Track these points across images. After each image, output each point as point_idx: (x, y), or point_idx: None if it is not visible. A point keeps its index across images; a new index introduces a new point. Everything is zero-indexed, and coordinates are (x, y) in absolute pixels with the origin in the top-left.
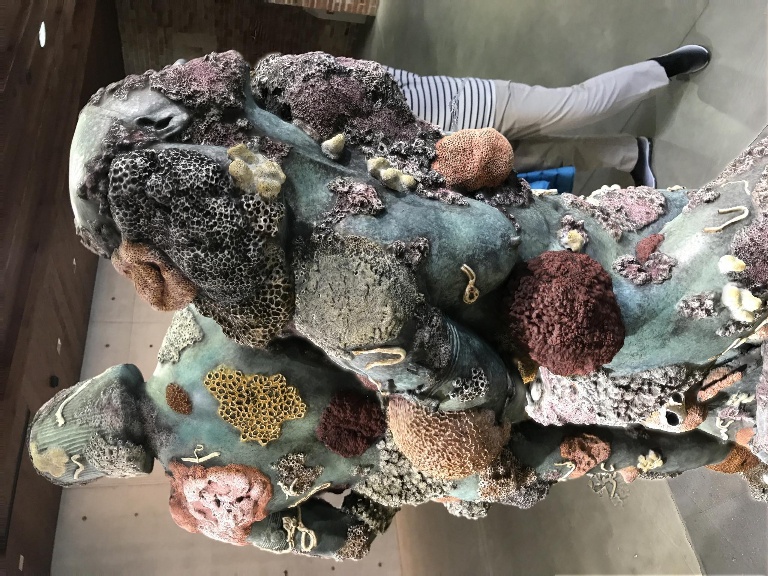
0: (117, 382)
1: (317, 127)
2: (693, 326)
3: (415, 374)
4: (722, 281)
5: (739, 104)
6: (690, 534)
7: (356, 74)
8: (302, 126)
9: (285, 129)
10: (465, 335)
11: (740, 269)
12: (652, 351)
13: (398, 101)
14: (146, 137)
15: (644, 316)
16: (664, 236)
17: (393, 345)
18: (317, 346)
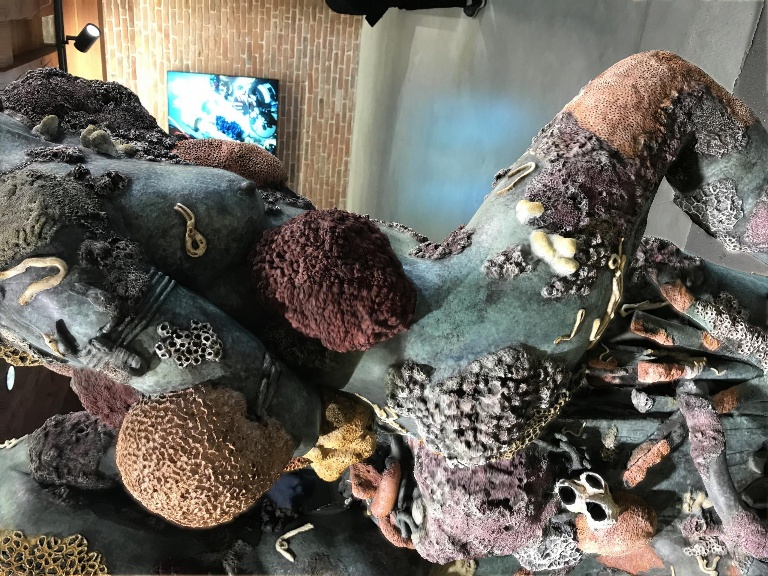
0: None
1: (28, 113)
2: (509, 288)
3: (81, 295)
4: (526, 231)
5: None
6: None
7: (84, 80)
8: (13, 115)
9: None
10: (193, 295)
11: (538, 210)
12: (470, 328)
13: (136, 107)
14: None
15: (446, 285)
16: None
17: (46, 254)
18: (142, 505)
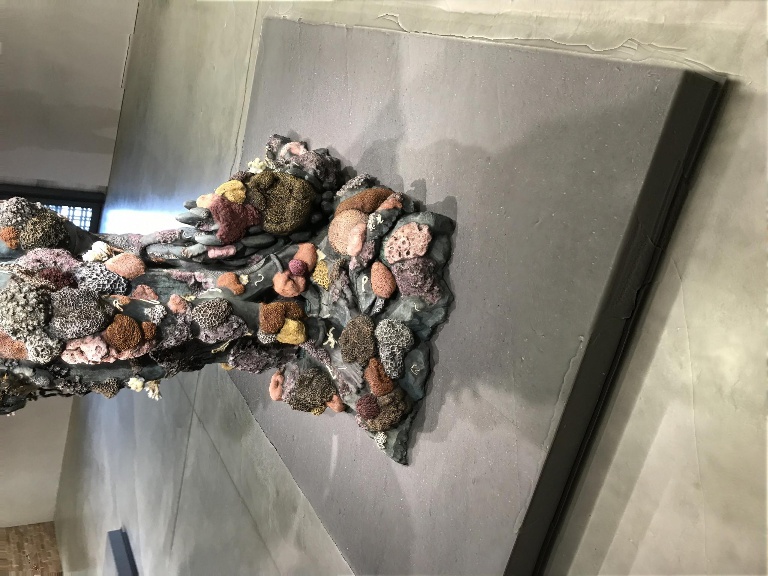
0: None
1: None
2: None
3: None
4: None
5: (336, 563)
6: (548, 431)
7: None
8: None
9: None
10: None
11: None
12: None
13: None
14: None
15: None
16: None
17: None
18: None
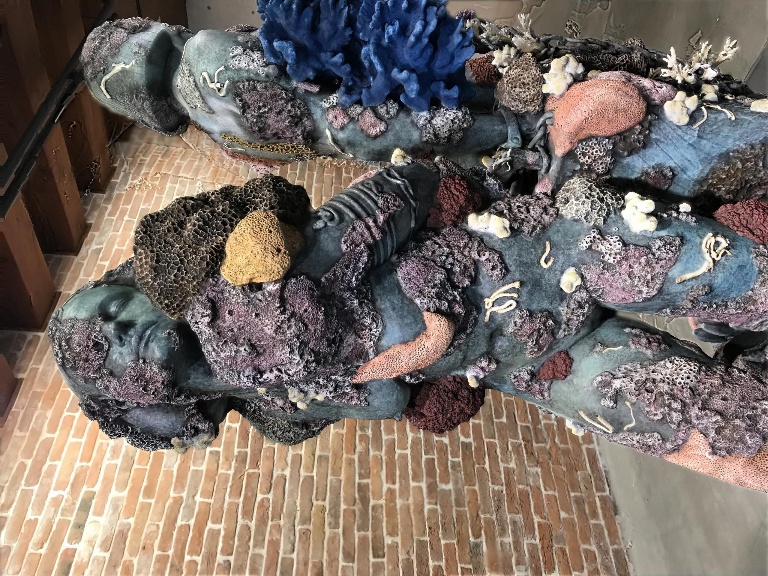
0: (145, 93)
1: None
2: None
3: None
4: (569, 420)
5: None
6: None
7: None
8: None
9: (217, 386)
10: None
11: None
12: None
13: None
14: (113, 415)
15: None
16: (567, 377)
17: None
18: None
